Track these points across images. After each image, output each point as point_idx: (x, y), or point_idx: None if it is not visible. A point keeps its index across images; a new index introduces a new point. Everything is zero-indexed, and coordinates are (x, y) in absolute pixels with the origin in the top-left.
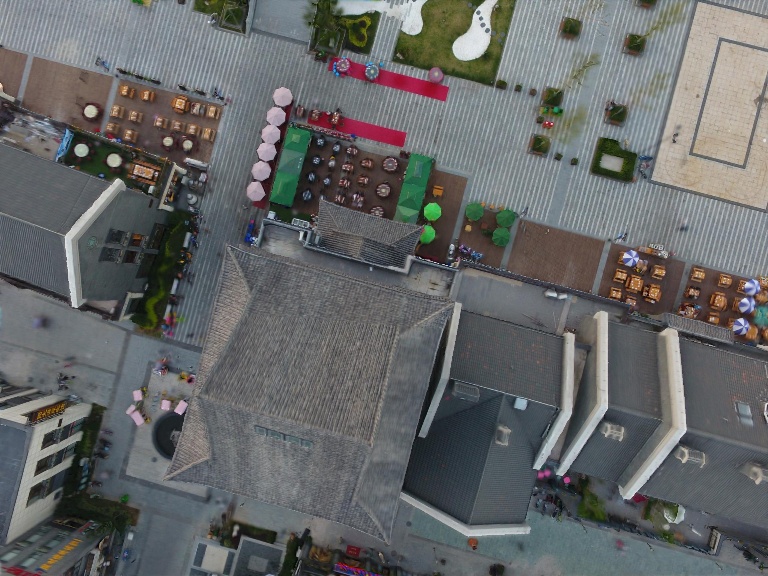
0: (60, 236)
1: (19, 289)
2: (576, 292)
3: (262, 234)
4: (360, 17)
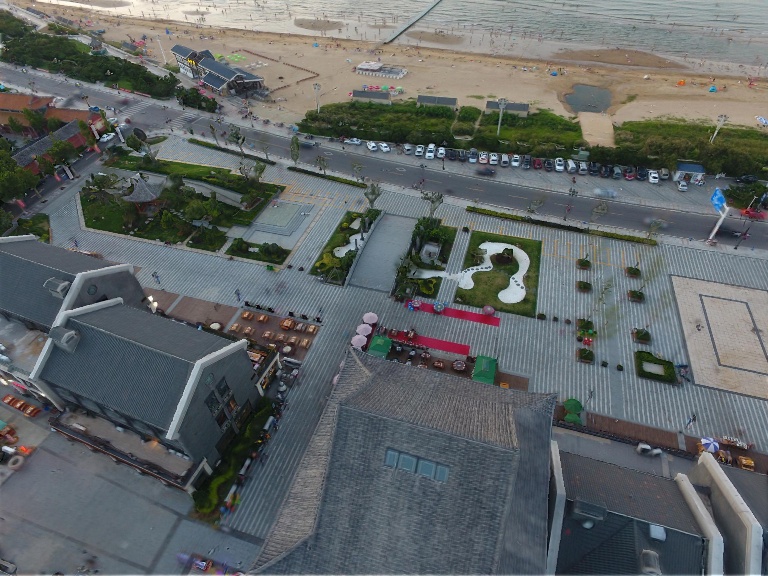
0: (190, 364)
1: (84, 467)
2: (669, 450)
3: None
4: (428, 279)
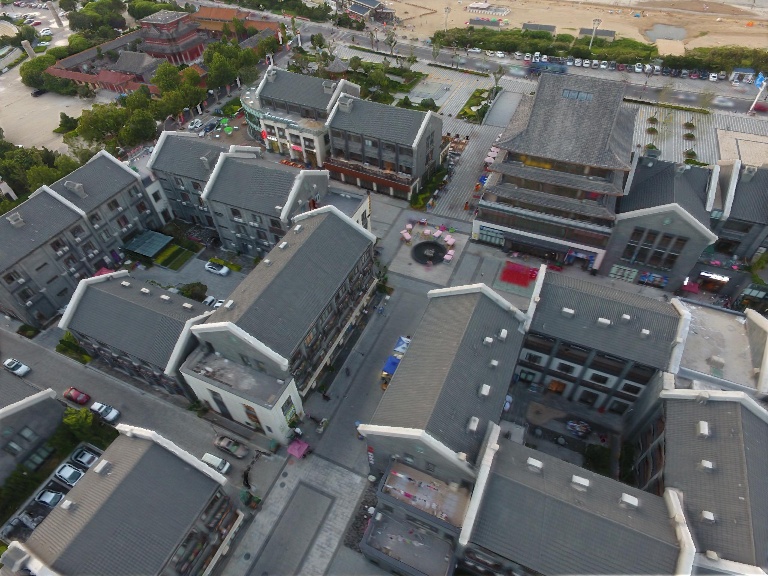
0: (423, 114)
1: None
2: None
3: None
4: None
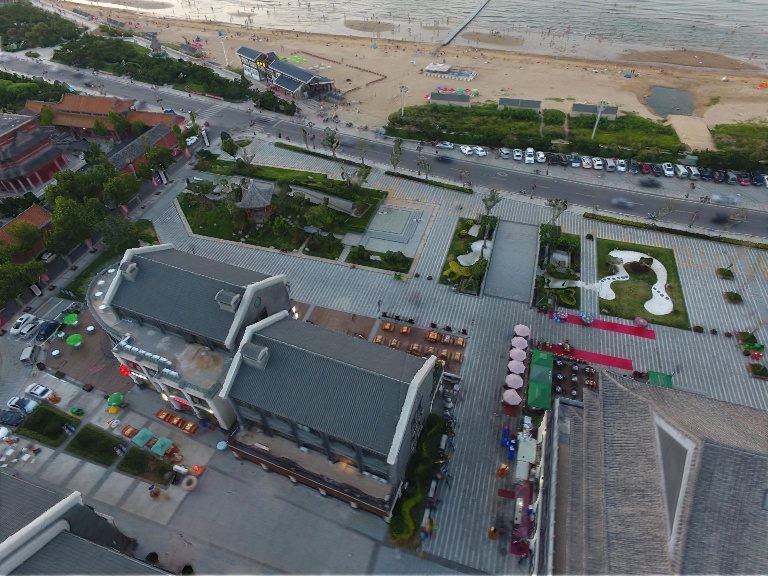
0: (402, 384)
1: (261, 488)
2: None
3: (558, 411)
4: (565, 289)
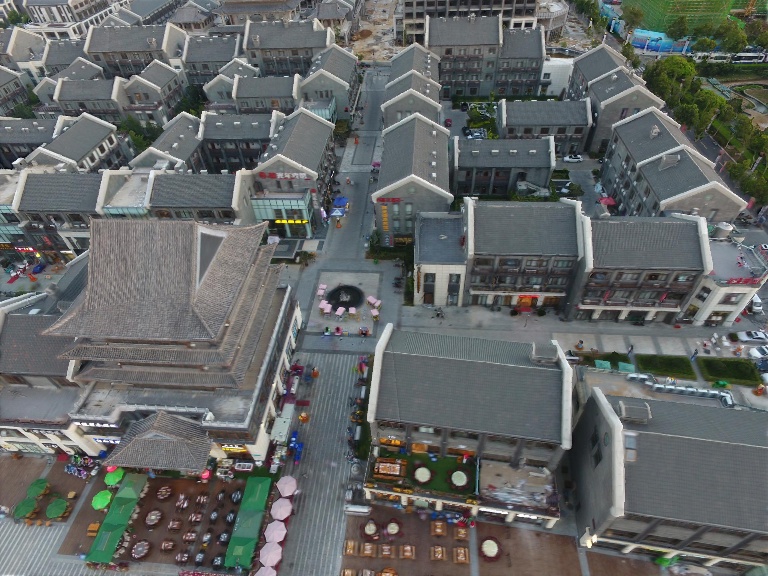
0: None
1: None
2: None
3: None
4: None
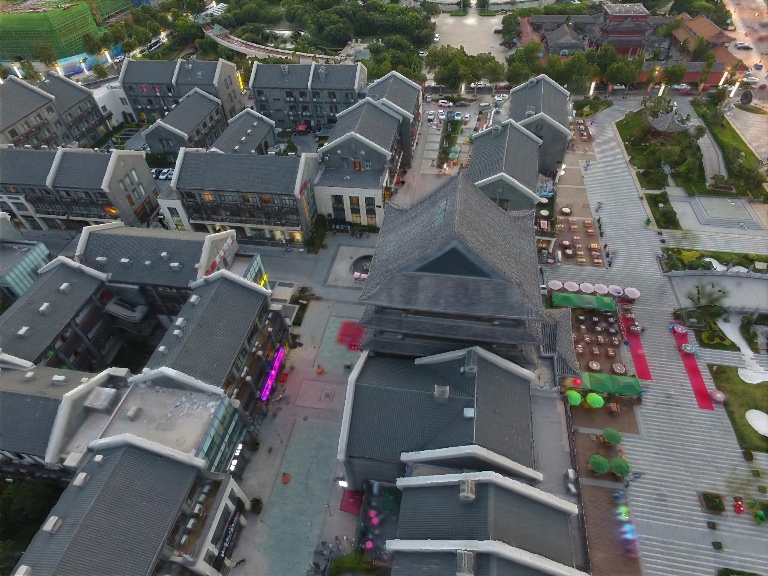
0: None
1: None
2: None
3: None
4: (727, 338)
